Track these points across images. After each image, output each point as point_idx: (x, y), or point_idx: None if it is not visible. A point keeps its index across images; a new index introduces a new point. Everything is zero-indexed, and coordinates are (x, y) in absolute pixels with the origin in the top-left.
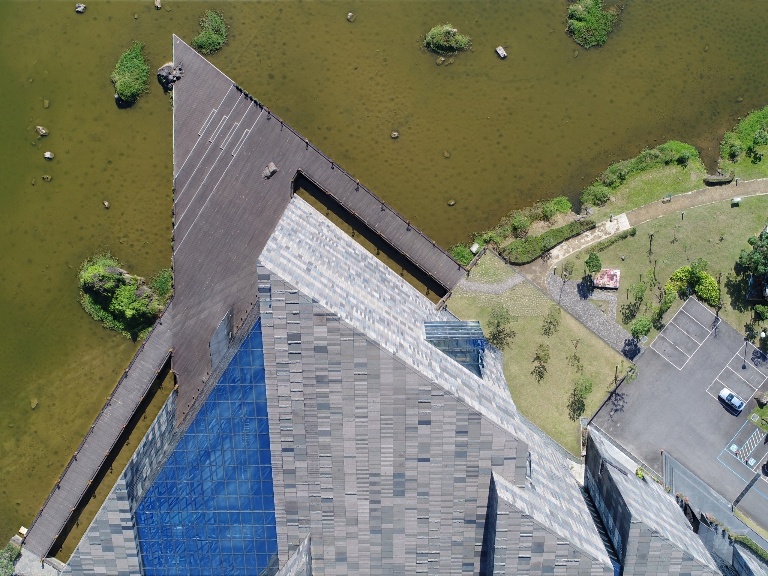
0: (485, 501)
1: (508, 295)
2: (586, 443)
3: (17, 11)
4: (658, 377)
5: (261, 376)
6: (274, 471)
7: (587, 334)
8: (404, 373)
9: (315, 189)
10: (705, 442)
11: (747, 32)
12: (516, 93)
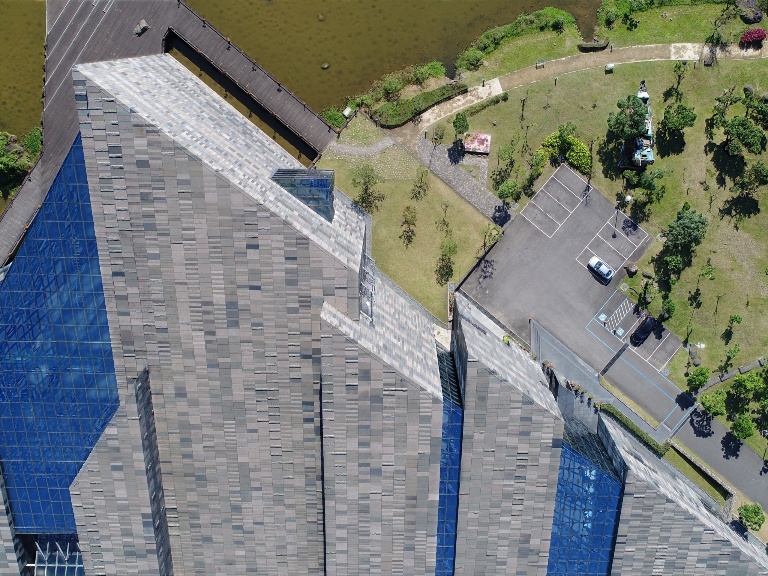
0: None
1: (378, 158)
2: (453, 308)
3: None
4: (528, 244)
5: (88, 195)
6: (106, 297)
7: (457, 199)
8: (228, 192)
9: (190, 51)
10: (574, 311)
11: None
12: None
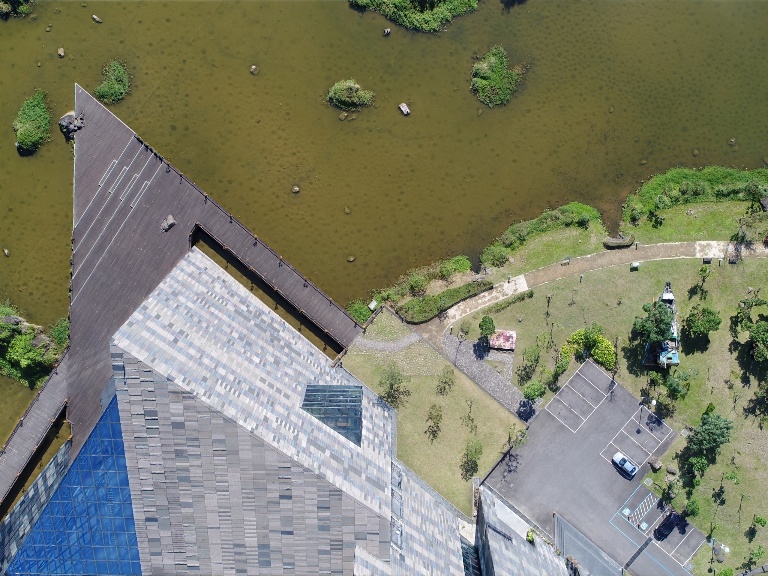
0: (351, 573)
1: (404, 354)
2: (477, 503)
3: None
4: (552, 439)
5: (123, 448)
6: (139, 539)
7: (482, 395)
8: (263, 450)
9: None
10: (598, 505)
11: (653, 94)
12: (418, 150)
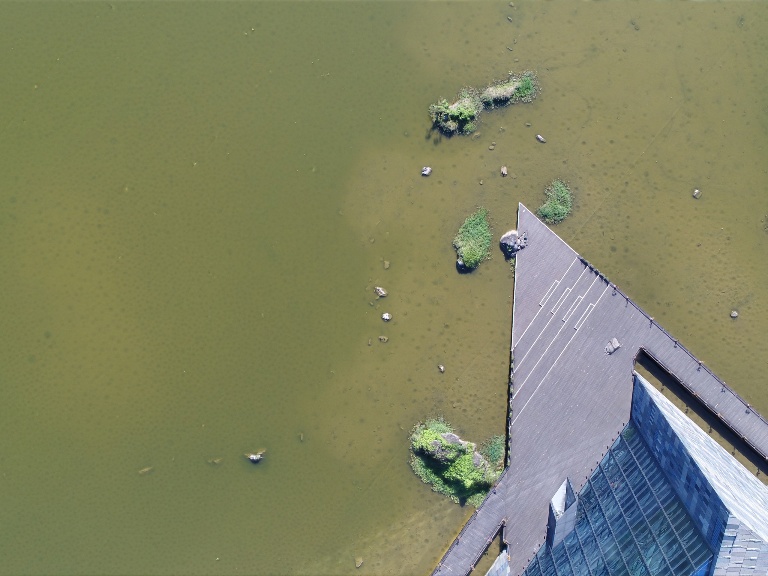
0: None
1: None
2: None
3: (362, 171)
4: None
5: None
6: None
7: None
8: None
9: (648, 362)
10: None
11: None
12: None
